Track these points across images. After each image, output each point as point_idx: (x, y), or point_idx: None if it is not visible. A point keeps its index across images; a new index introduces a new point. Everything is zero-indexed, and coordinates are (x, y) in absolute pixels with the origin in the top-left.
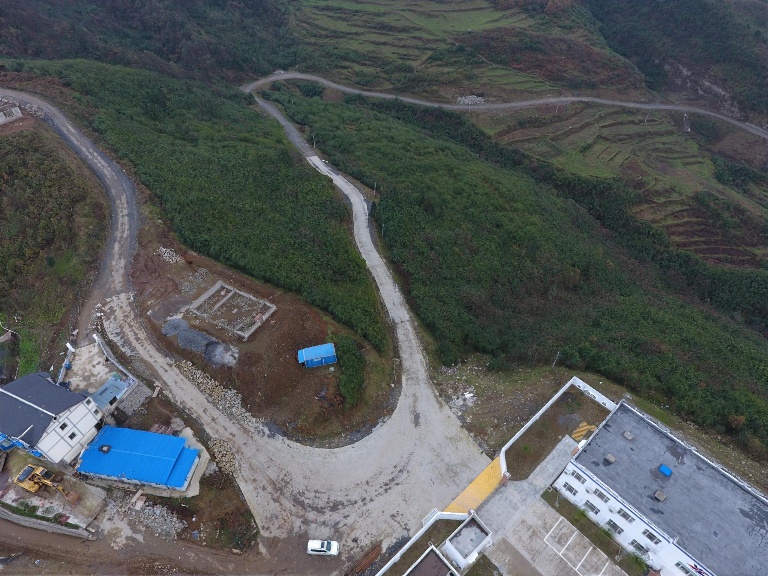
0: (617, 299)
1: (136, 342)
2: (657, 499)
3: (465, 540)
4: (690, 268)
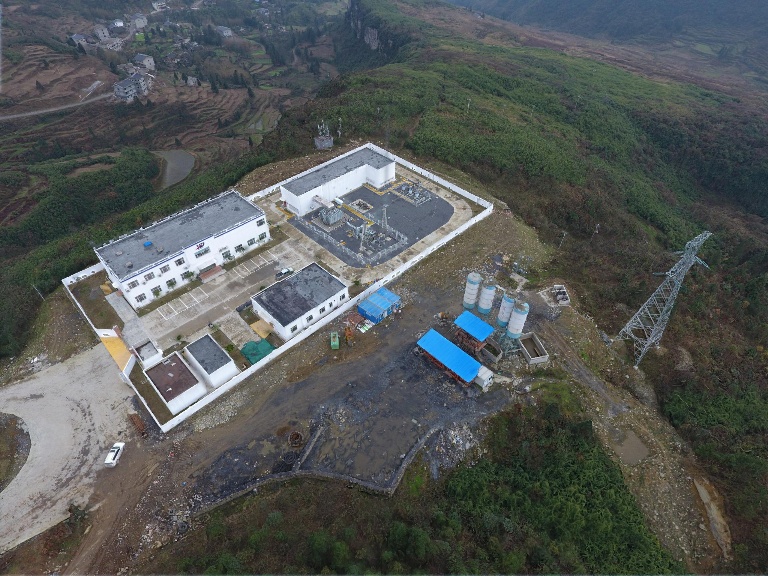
0: (4, 277)
1: None
2: (161, 252)
3: (148, 354)
4: (7, 237)
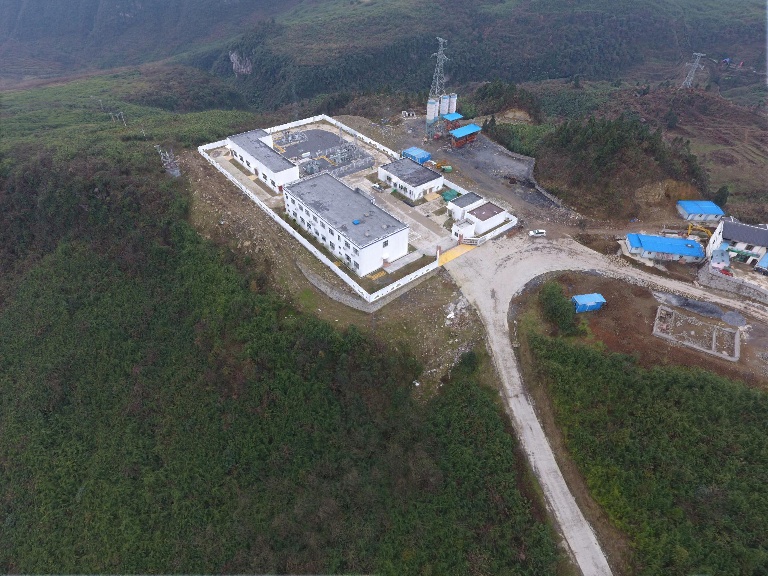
0: None
1: (754, 309)
2: None
3: None
4: None
